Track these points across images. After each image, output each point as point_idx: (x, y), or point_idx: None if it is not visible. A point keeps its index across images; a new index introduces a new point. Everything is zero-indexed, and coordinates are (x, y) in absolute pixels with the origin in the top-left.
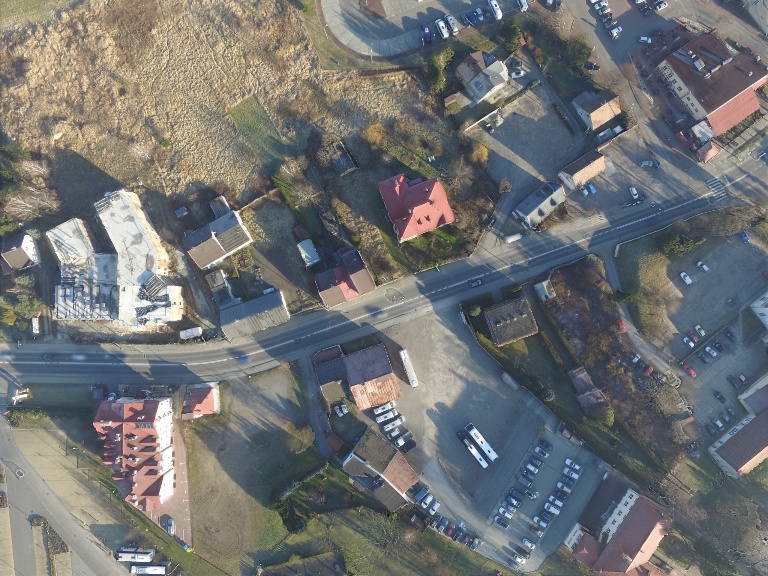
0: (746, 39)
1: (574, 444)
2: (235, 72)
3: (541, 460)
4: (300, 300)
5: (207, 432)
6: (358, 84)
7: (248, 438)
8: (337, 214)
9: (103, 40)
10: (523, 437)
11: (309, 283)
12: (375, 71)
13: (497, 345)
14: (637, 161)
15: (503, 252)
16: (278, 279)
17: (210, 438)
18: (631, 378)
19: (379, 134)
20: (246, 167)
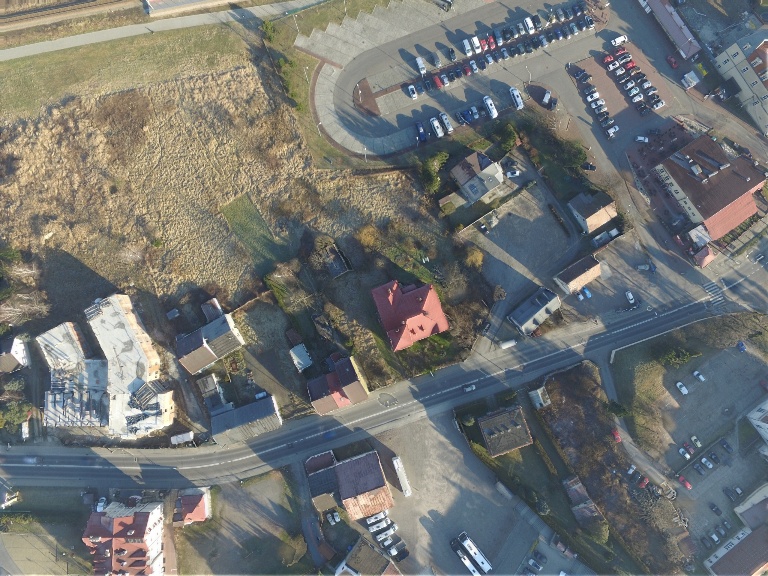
0: (744, 138)
1: (568, 556)
2: (227, 170)
3: (535, 572)
4: (292, 404)
5: (198, 538)
6: (352, 183)
7: (240, 544)
8: (330, 318)
9: (94, 138)
10: (517, 547)
11: (301, 387)
12: (369, 170)
13: (491, 456)
14: (633, 265)
15: (498, 357)
16: (270, 383)
17: (201, 544)
18: (626, 490)
19: (373, 237)
20: (238, 267)
